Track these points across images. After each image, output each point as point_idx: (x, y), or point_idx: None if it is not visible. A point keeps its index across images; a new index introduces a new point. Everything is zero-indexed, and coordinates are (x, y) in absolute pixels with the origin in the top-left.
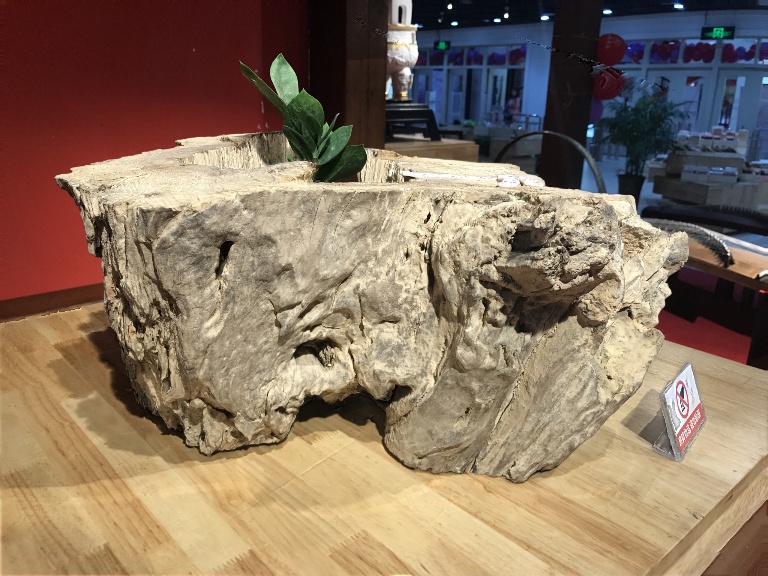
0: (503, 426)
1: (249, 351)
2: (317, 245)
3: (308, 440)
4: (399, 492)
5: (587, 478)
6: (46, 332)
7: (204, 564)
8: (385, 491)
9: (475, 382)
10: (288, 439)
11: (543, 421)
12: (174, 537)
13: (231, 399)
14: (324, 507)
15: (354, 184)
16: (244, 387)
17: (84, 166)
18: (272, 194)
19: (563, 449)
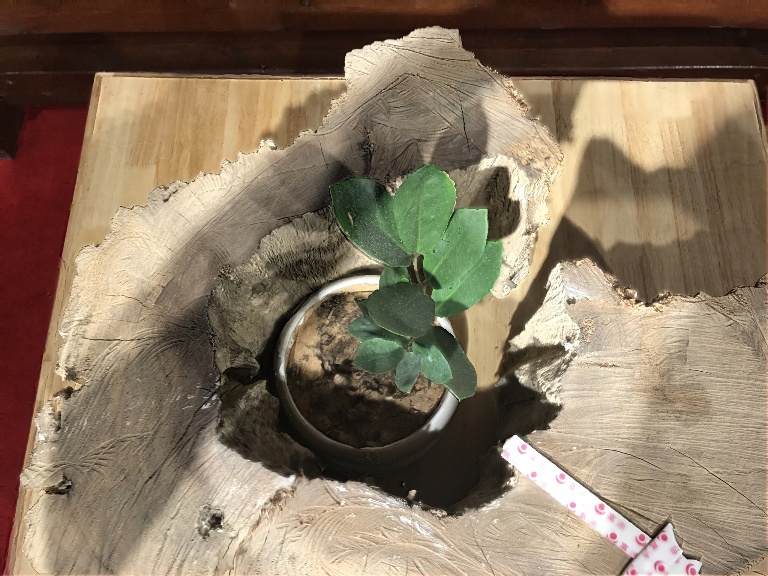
0: None
1: None
2: None
3: None
4: None
5: None
6: (229, 132)
7: None
8: None
9: None
10: None
11: None
12: None
13: None
14: None
15: (356, 507)
16: None
17: (129, 215)
18: None
19: None
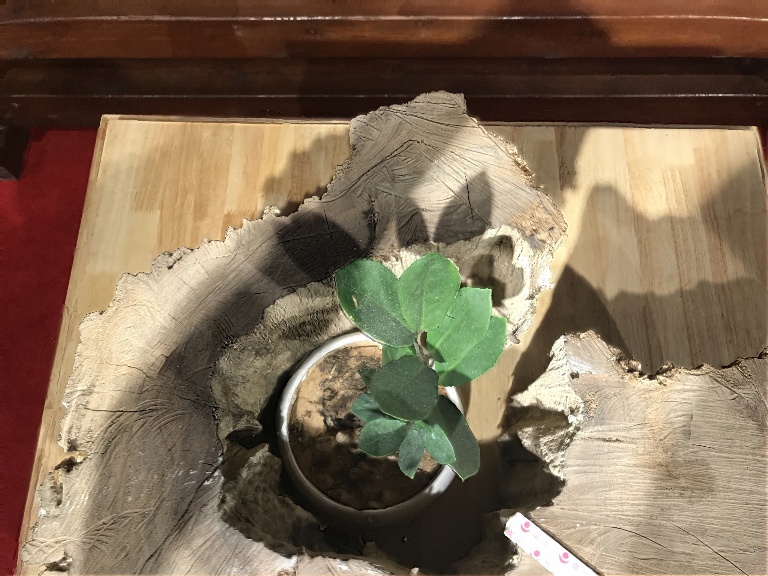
0: None
1: None
2: None
3: None
4: None
5: None
6: (233, 177)
7: None
8: None
9: None
10: None
11: None
12: None
13: None
14: None
15: None
16: None
17: (133, 282)
18: None
19: None
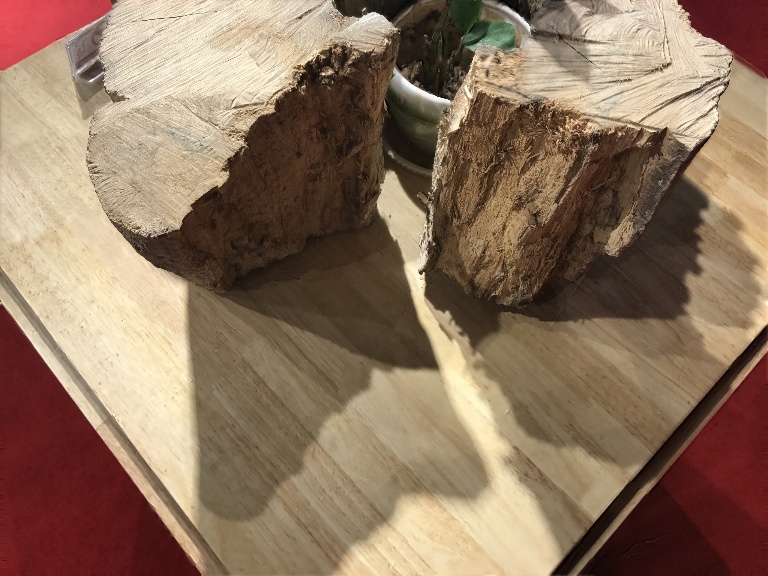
0: None
1: None
2: None
3: None
4: None
5: None
6: None
7: None
8: None
9: None
10: None
11: None
12: None
13: None
14: None
15: None
16: None
17: None
18: None
19: None
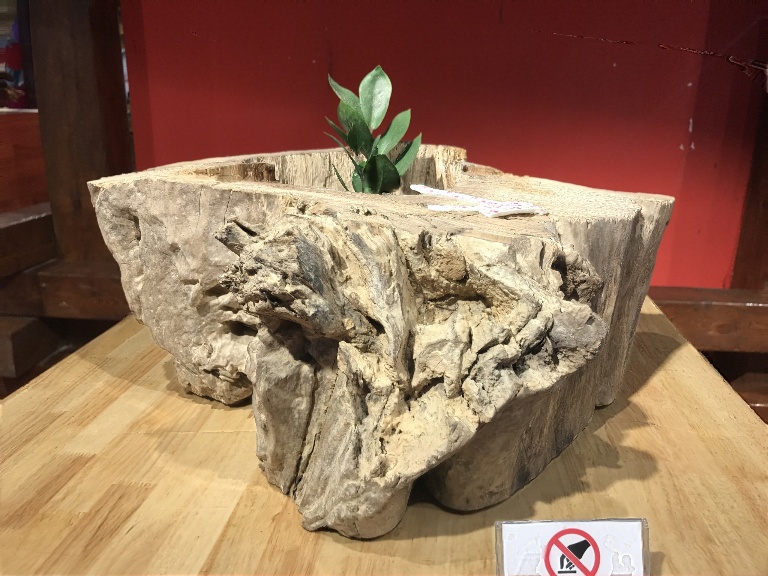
0: (310, 462)
1: (171, 311)
2: (202, 233)
3: (252, 414)
4: (223, 478)
5: (367, 568)
6: None
7: (69, 447)
8: (218, 472)
9: (257, 395)
10: (244, 407)
11: (325, 472)
12: (89, 426)
13: (167, 347)
14: (170, 457)
15: (309, 188)
16: (175, 341)
17: None
18: (154, 182)
19: (334, 514)
